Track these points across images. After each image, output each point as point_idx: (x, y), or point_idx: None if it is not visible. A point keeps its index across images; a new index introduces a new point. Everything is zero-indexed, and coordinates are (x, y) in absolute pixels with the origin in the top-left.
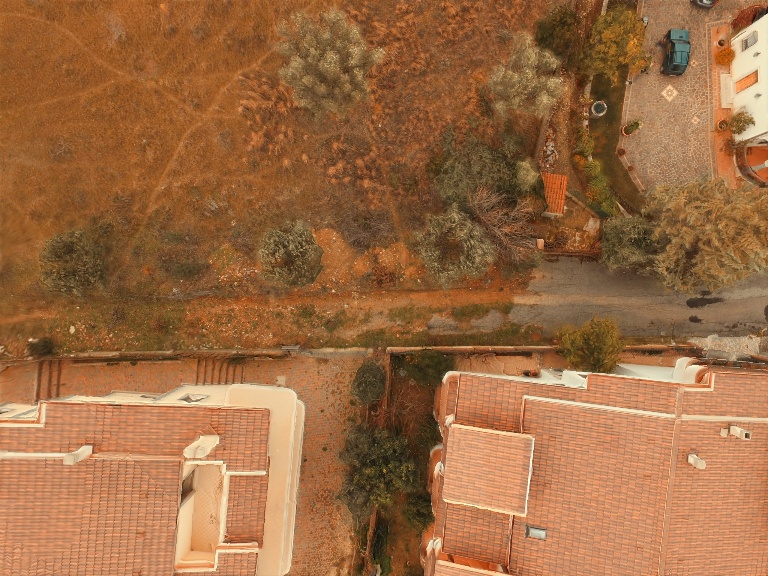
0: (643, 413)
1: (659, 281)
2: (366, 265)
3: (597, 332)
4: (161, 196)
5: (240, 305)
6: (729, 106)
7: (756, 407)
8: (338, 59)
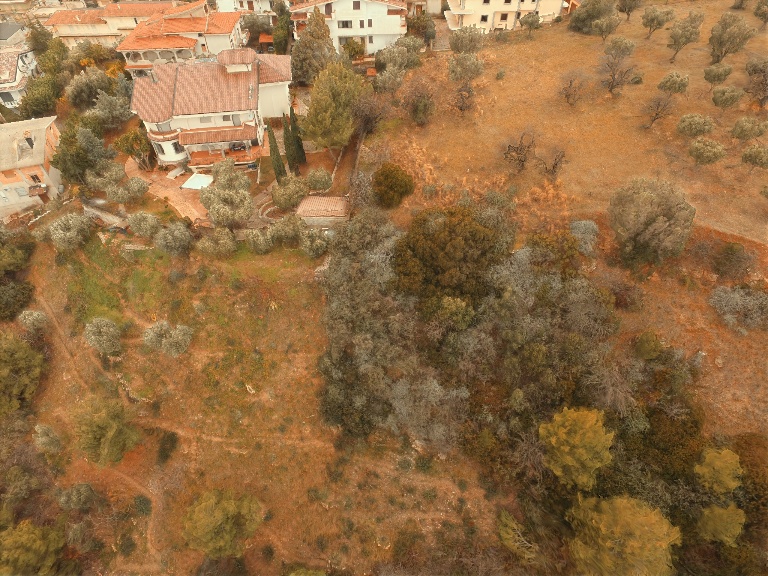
0: None
1: None
2: None
3: (354, 45)
4: None
5: None
6: None
7: None
8: None
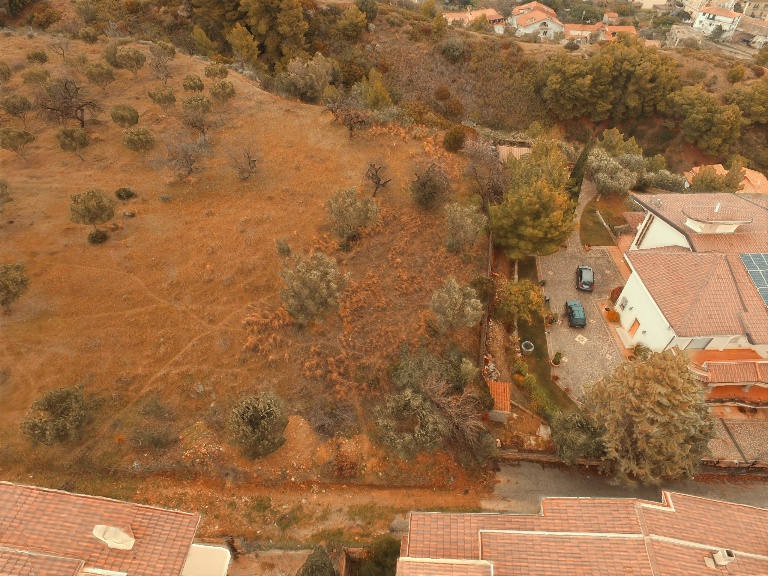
0: (608, 535)
1: (619, 472)
2: (328, 453)
3: None
4: (158, 380)
5: (194, 490)
6: (631, 347)
7: (736, 539)
8: (320, 275)
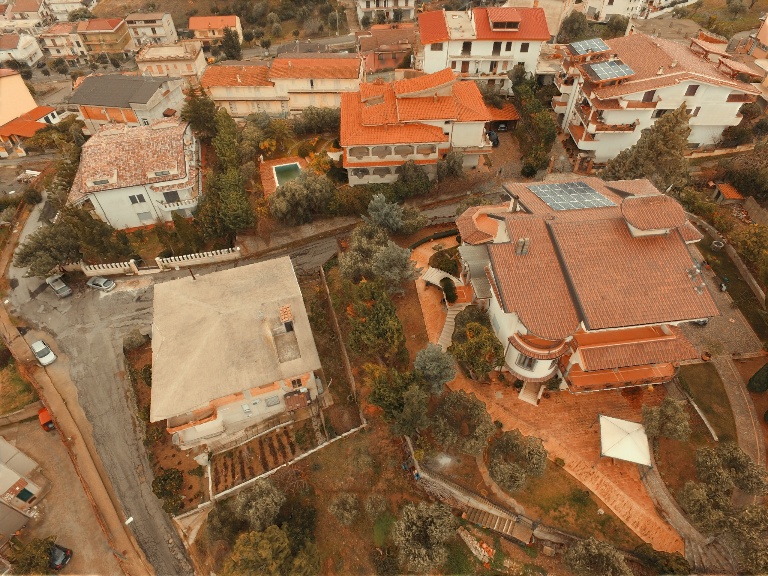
0: (698, 74)
1: None
2: None
3: None
4: None
5: None
6: None
7: None
8: None
